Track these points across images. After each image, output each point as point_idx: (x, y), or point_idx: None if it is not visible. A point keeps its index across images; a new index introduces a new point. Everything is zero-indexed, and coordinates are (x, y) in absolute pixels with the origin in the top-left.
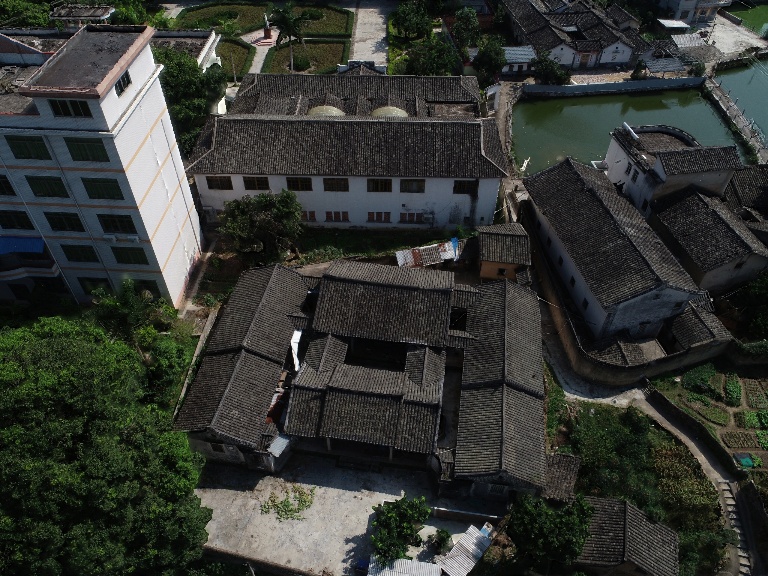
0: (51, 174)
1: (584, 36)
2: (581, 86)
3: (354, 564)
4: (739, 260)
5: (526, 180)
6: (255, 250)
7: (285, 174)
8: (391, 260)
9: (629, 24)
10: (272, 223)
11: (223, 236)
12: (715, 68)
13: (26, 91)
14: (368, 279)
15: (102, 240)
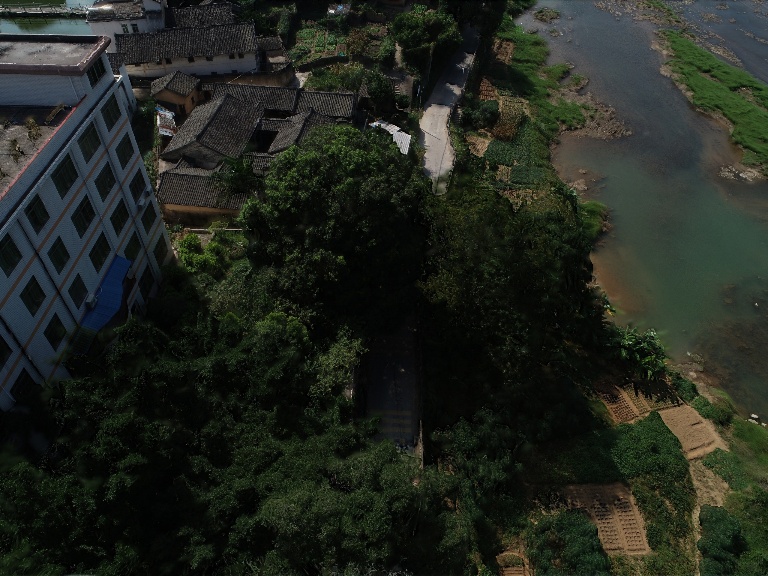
0: (104, 163)
1: None
2: None
3: None
4: None
5: None
6: None
7: None
8: (163, 141)
9: None
10: None
11: None
12: None
13: (84, 67)
14: (201, 127)
15: (136, 216)
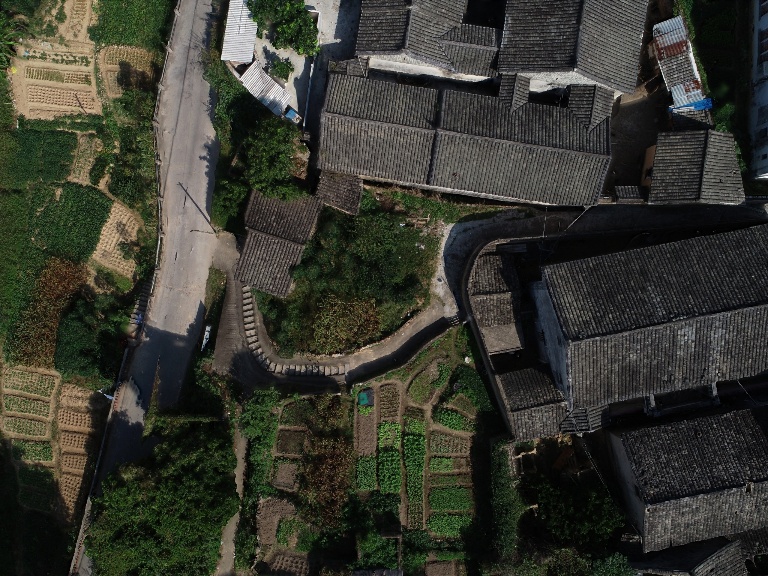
0: None
1: None
2: None
3: None
4: None
5: None
6: None
7: None
8: (670, 14)
9: None
10: None
11: None
12: None
13: None
14: None
15: None
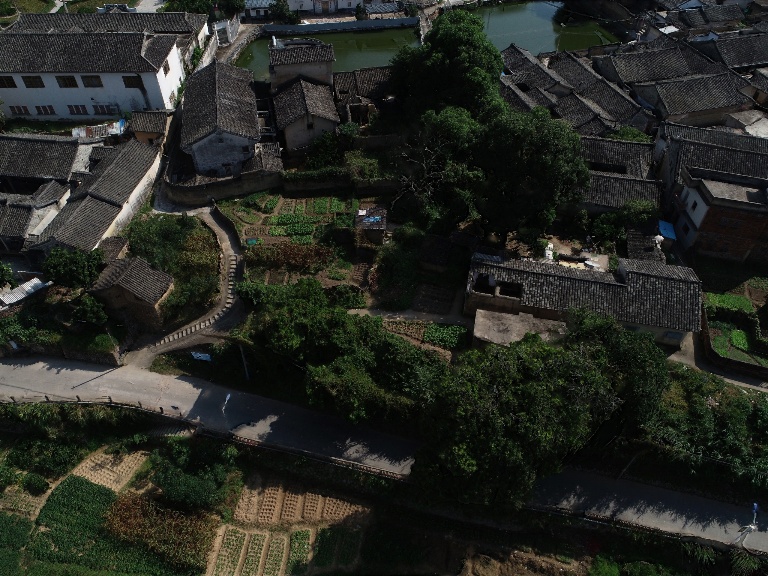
0: None
1: None
2: (311, 25)
3: None
4: (307, 121)
5: (187, 78)
6: None
7: None
8: None
9: None
10: None
11: None
12: (434, 11)
13: None
14: None
15: None
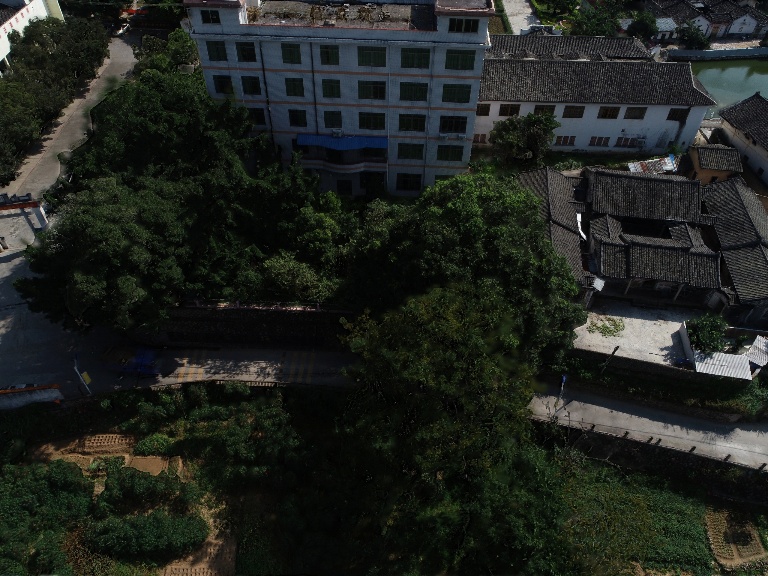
0: (422, 81)
1: (712, 11)
2: (719, 51)
3: (673, 362)
4: None
5: (722, 111)
6: (527, 157)
7: (538, 101)
8: (623, 170)
9: (747, 2)
10: (541, 135)
11: (499, 147)
12: None
13: (441, 10)
14: None
15: (434, 139)
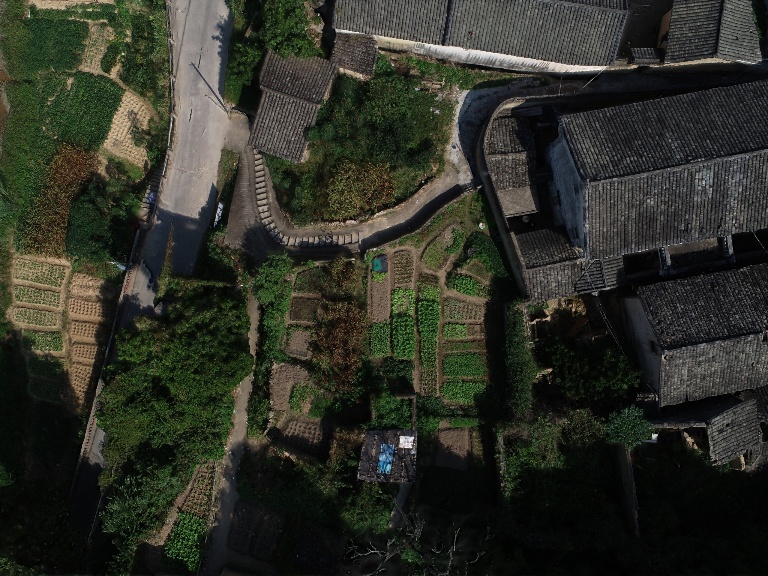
0: None
1: None
2: None
3: None
4: None
5: None
6: None
7: None
8: None
9: None
10: None
11: None
12: None
13: None
14: None
15: None
